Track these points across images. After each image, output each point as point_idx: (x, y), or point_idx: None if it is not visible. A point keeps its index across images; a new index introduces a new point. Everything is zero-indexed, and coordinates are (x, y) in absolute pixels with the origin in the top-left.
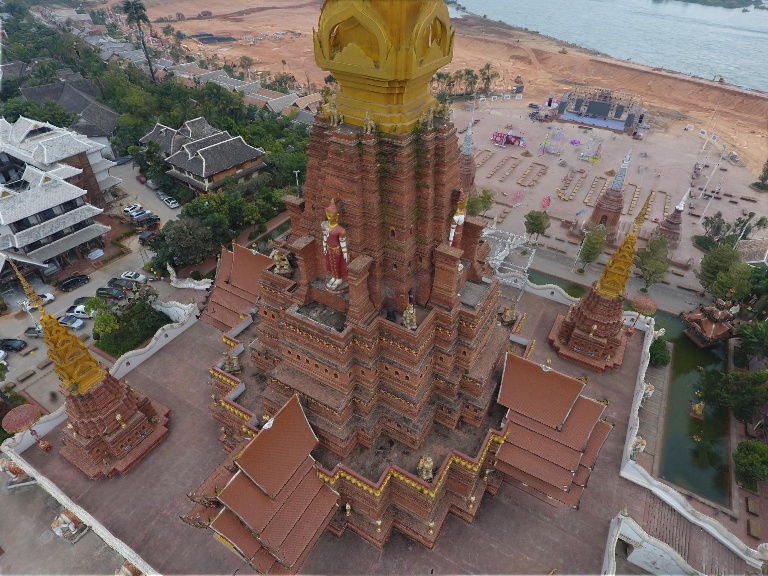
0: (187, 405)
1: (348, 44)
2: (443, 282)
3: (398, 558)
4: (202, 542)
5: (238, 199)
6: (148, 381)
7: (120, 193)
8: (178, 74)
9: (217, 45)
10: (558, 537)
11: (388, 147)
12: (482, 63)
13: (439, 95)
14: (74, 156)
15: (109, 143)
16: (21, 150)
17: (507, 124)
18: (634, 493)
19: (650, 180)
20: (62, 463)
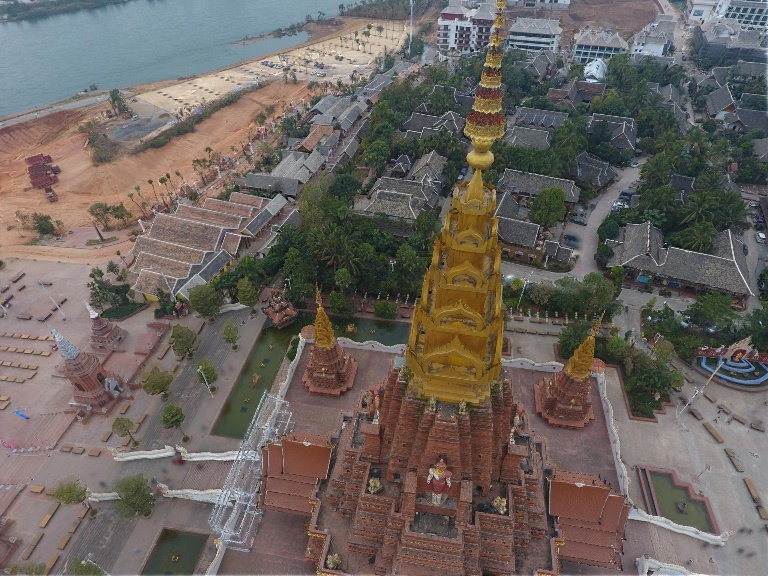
0: None
1: None
2: None
3: None
4: (609, 570)
5: None
6: None
7: None
8: None
9: None
10: None
11: None
12: None
13: None
14: None
15: None
16: None
17: None
18: None
19: None
20: None
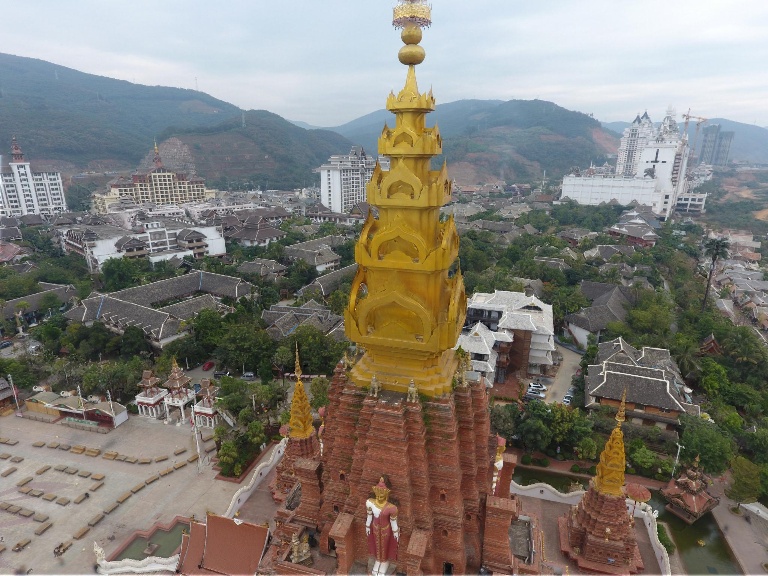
0: None
1: None
2: None
3: None
4: None
5: (584, 427)
6: None
7: (552, 373)
8: None
9: None
10: None
11: None
12: None
13: None
14: (522, 330)
15: None
16: None
17: None
18: None
19: None
20: None
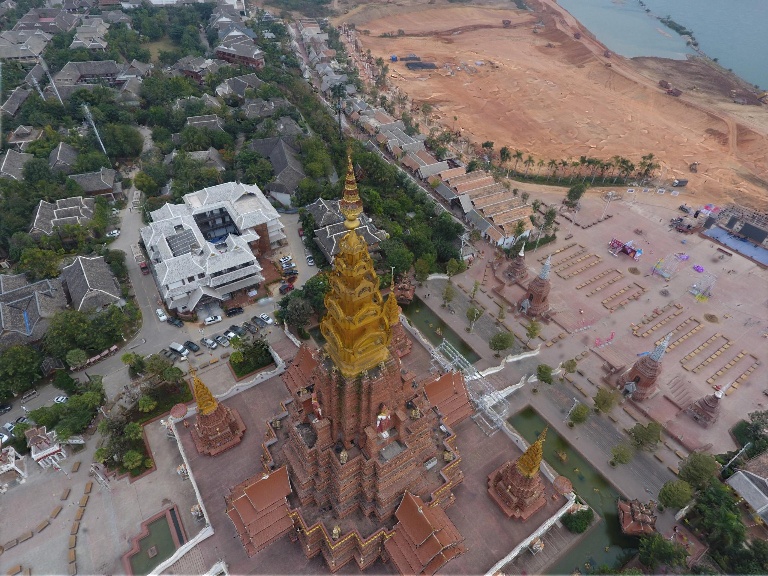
0: (256, 428)
1: (329, 336)
2: (370, 443)
3: (314, 569)
4: None
5: None
6: (244, 404)
7: (284, 241)
8: (367, 120)
9: (419, 73)
10: None
11: (343, 380)
12: (667, 134)
13: (576, 186)
14: (259, 224)
15: (290, 197)
16: (233, 211)
17: (638, 228)
18: None
19: (751, 338)
20: (190, 437)
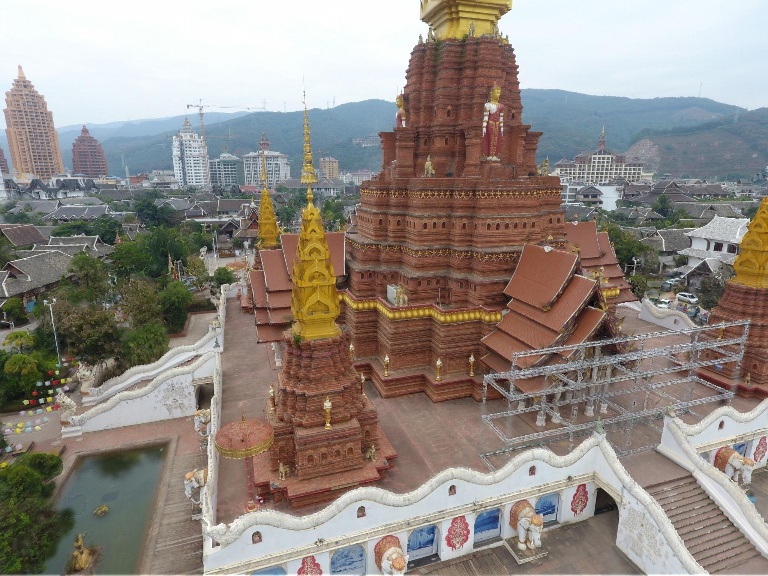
0: None
1: None
2: None
3: None
4: None
5: None
6: None
7: None
8: None
9: None
10: None
11: None
12: None
13: None
14: None
15: None
16: None
17: None
18: None
19: None
20: None
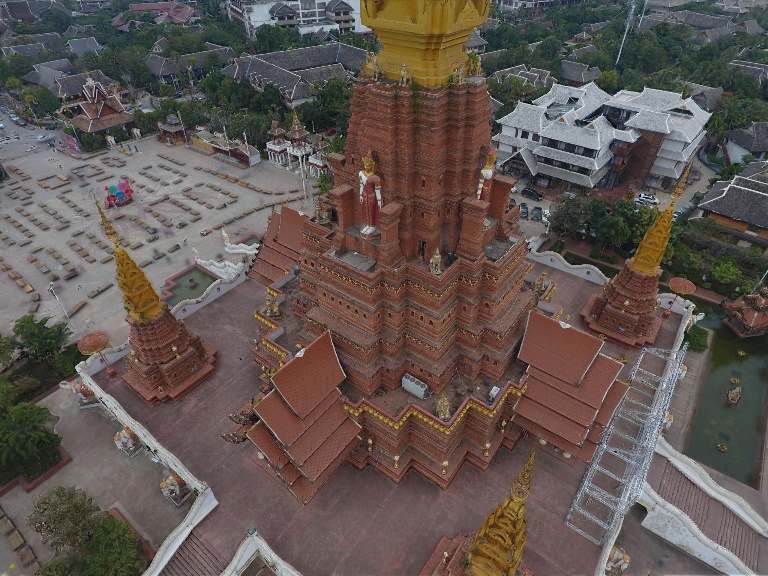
0: None
1: None
2: None
3: None
4: None
5: None
6: None
7: None
8: None
9: None
10: (226, 448)
11: None
12: None
13: None
14: (652, 132)
15: None
16: None
17: None
18: (234, 546)
19: None
20: None
